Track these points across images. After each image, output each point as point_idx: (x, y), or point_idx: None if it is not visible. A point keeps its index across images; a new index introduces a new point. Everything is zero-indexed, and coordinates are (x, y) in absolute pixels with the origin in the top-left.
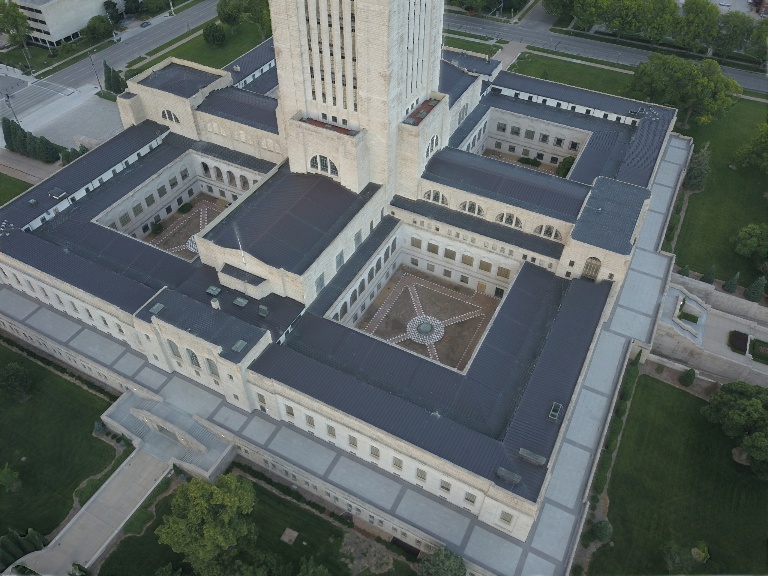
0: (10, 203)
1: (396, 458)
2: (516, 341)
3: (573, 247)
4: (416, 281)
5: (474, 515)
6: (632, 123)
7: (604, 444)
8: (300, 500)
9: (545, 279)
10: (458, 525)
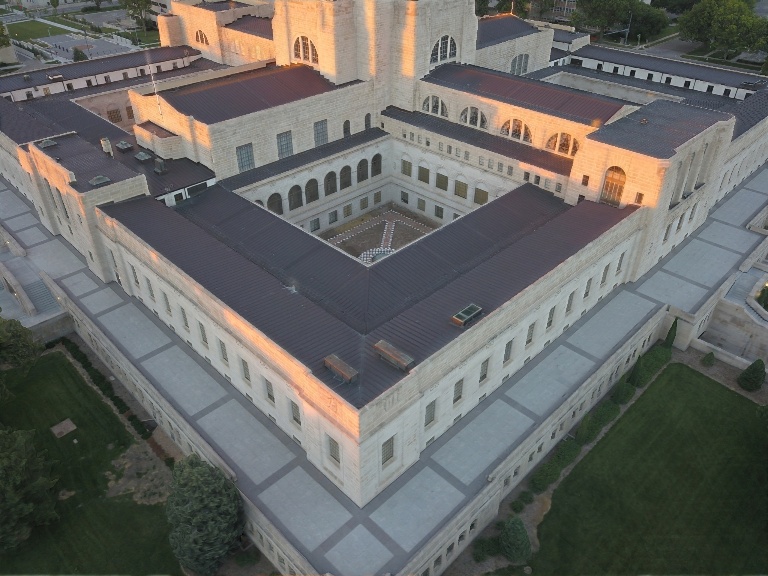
0: (7, 76)
1: (222, 343)
2: (467, 251)
3: (587, 150)
4: (400, 218)
5: (304, 452)
6: (746, 97)
7: (575, 430)
8: (106, 392)
9: (547, 203)
10: (273, 458)
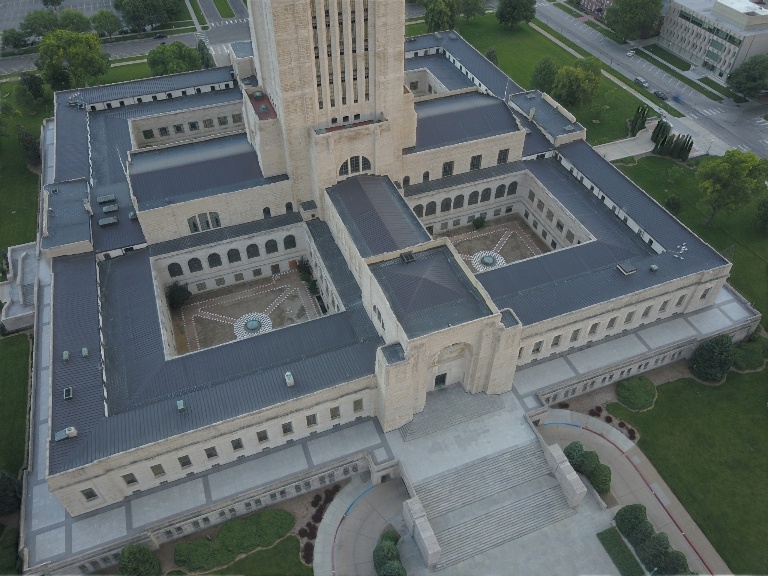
0: None
1: None
2: None
3: None
4: None
5: None
6: None
7: None
8: None
9: None
10: None
